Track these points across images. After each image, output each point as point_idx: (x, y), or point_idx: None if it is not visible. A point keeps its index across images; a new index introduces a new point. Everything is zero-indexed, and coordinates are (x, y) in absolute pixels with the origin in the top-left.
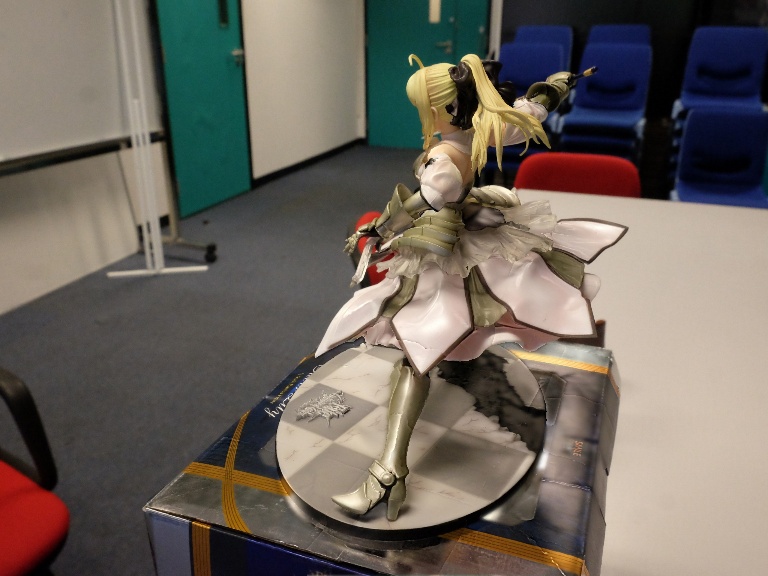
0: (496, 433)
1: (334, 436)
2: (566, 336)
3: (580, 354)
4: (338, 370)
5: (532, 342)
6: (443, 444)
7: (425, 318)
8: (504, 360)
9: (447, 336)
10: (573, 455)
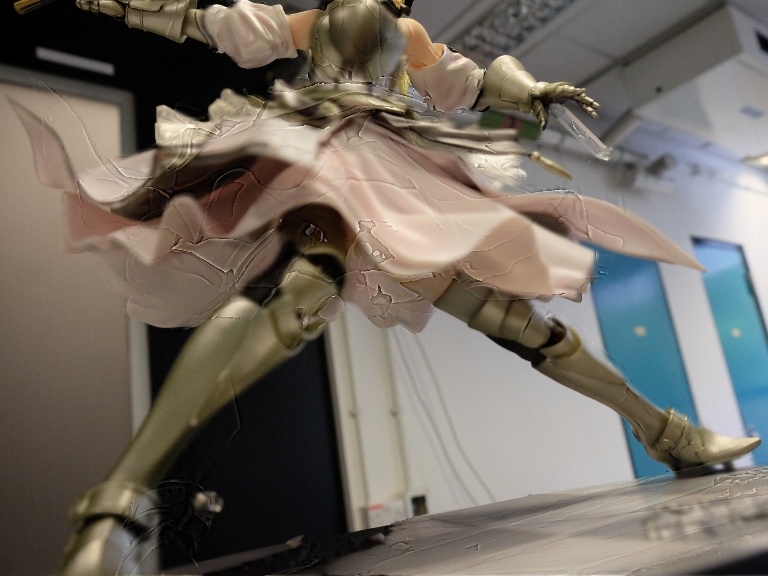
0: None
1: None
2: None
3: None
4: None
5: None
6: None
7: None
8: None
9: None
10: None
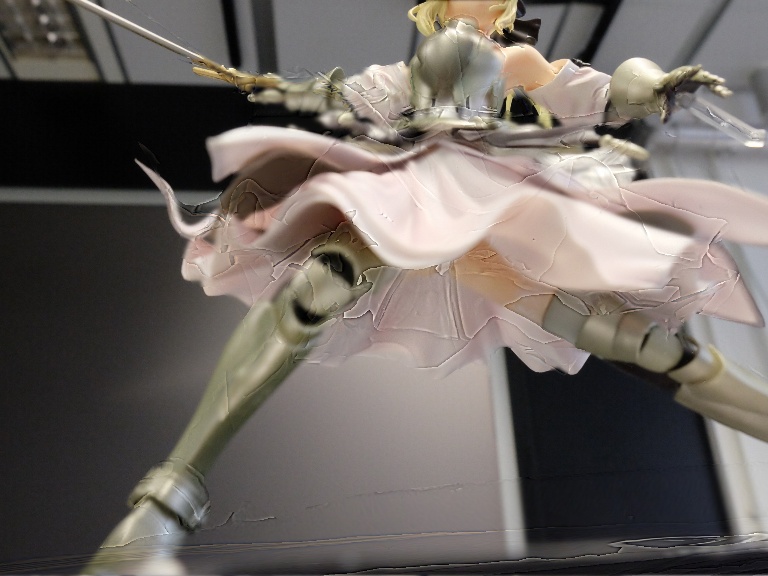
0: None
1: None
2: None
3: None
4: None
5: None
6: None
7: None
8: None
9: None
10: None
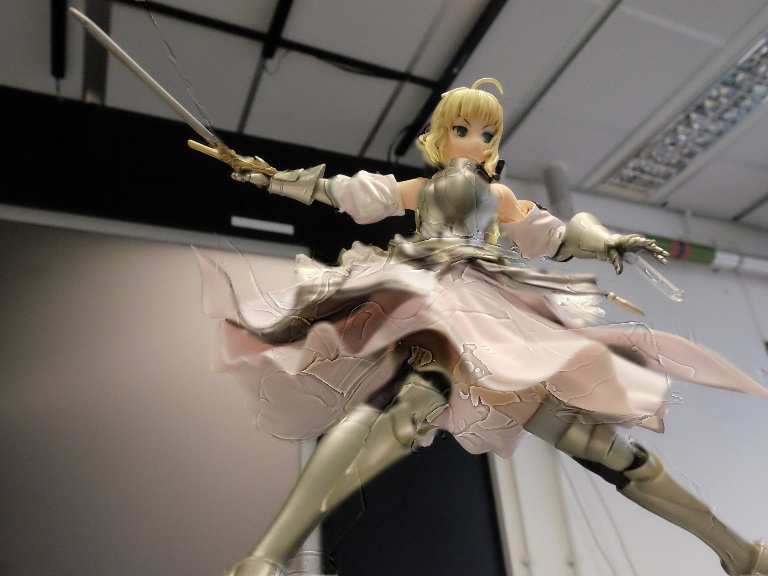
0: None
1: None
2: None
3: None
4: None
5: None
6: None
7: None
8: None
9: None
10: None
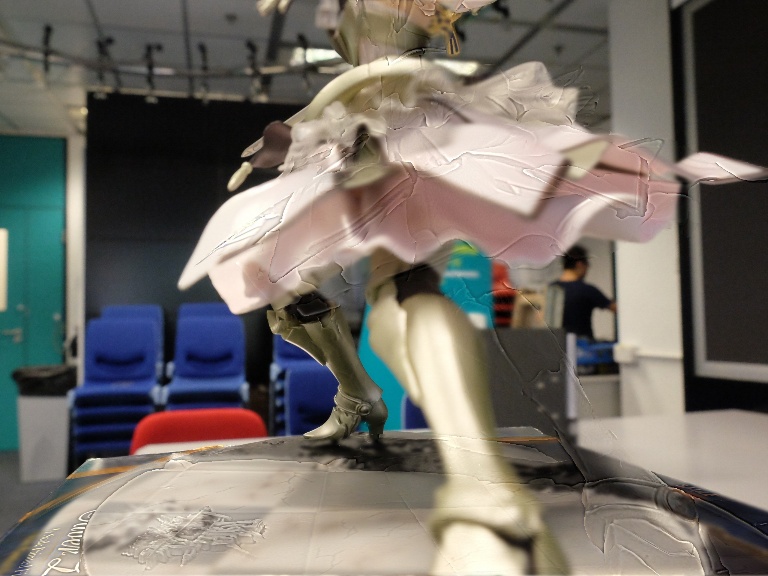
0: (581, 491)
1: (290, 567)
2: (760, 181)
3: (504, 432)
4: (158, 492)
5: (689, 219)
6: (530, 523)
7: (548, 139)
8: (435, 440)
9: (618, 158)
10: (709, 496)
